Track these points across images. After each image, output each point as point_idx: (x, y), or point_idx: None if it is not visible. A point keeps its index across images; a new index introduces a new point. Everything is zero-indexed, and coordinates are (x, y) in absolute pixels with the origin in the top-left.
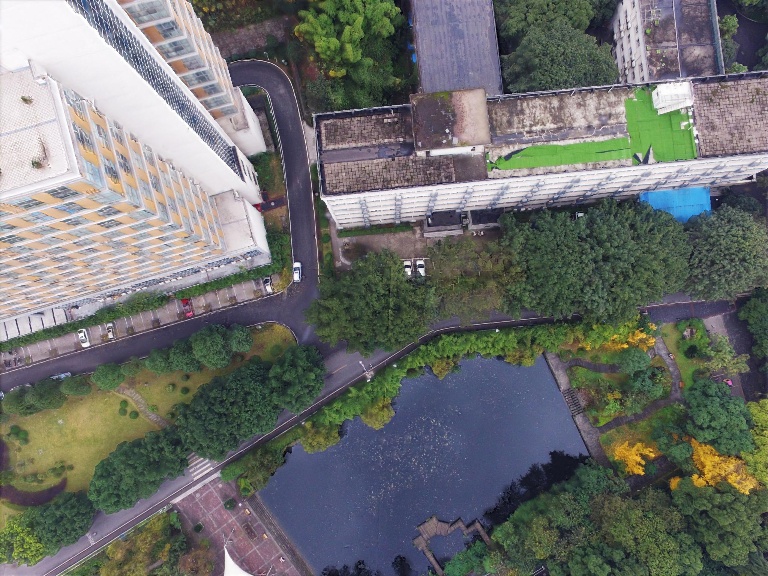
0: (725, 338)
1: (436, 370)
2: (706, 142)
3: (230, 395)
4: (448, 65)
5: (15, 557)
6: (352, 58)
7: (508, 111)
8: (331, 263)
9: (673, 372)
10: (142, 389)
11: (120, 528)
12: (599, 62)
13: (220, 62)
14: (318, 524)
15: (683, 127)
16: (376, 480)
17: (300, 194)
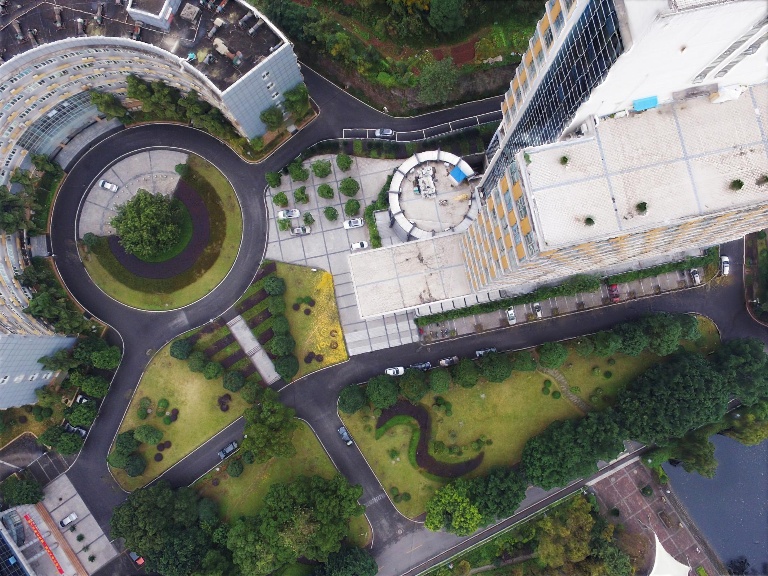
0: None
1: None
2: None
3: (696, 381)
4: None
5: (456, 526)
6: None
7: None
8: (766, 259)
9: None
10: (565, 370)
11: (533, 506)
12: None
13: None
14: (728, 518)
15: None
16: None
17: None
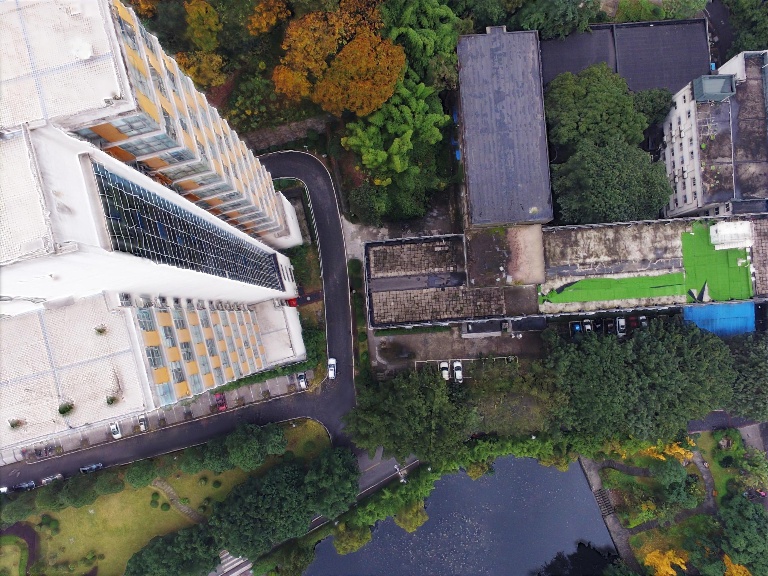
0: (762, 454)
1: (471, 475)
2: (763, 280)
3: (266, 502)
4: (497, 176)
5: None
6: (399, 171)
7: (562, 242)
8: (367, 362)
9: (707, 480)
10: (174, 482)
11: None
12: (654, 184)
13: (267, 183)
14: None
15: (740, 264)
16: (405, 575)
17: (337, 290)
